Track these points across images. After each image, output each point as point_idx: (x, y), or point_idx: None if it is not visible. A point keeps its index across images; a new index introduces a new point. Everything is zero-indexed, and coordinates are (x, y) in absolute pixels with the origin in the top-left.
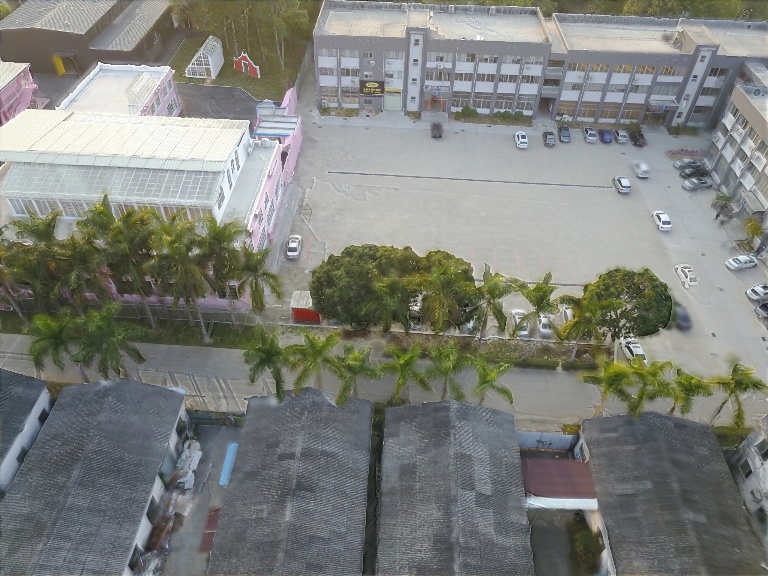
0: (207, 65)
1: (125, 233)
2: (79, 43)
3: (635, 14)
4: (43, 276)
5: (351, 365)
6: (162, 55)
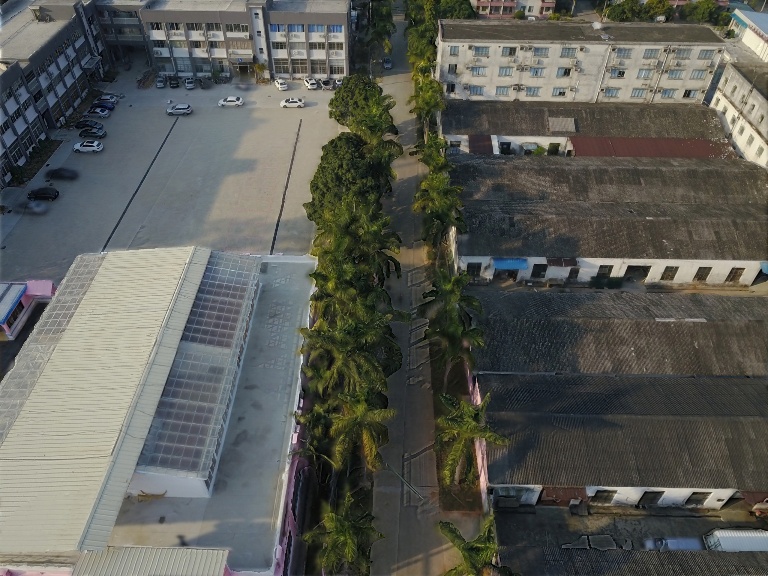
0: None
1: None
2: None
3: None
4: (384, 361)
5: None
6: None
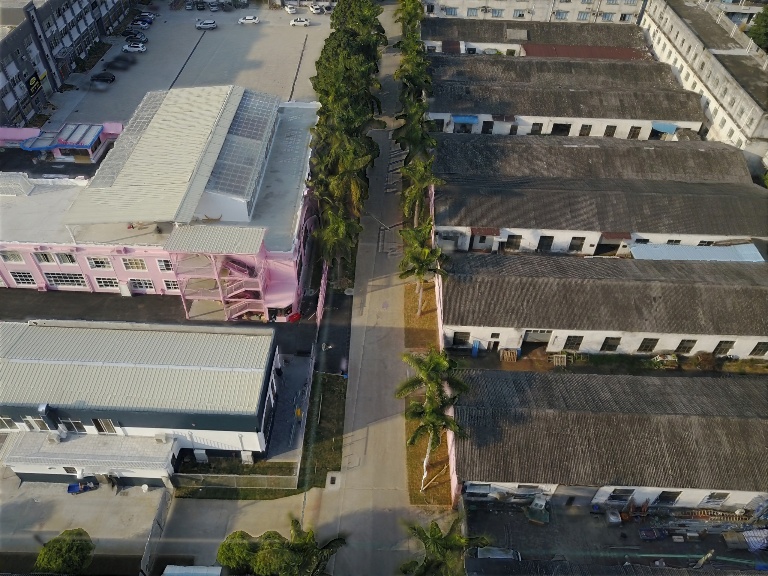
0: None
1: None
2: None
3: None
4: (367, 149)
5: None
6: None
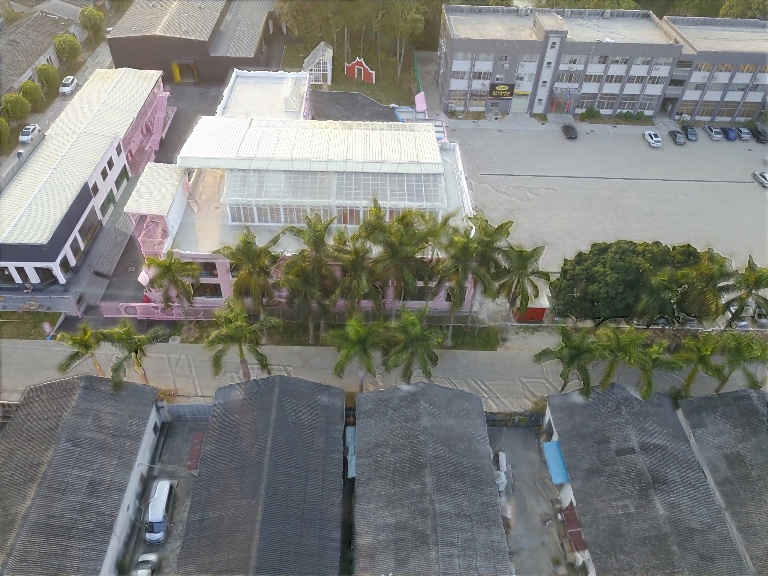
0: (325, 71)
1: (405, 236)
2: (200, 50)
3: (734, 17)
4: (318, 282)
5: (661, 358)
6: (270, 62)
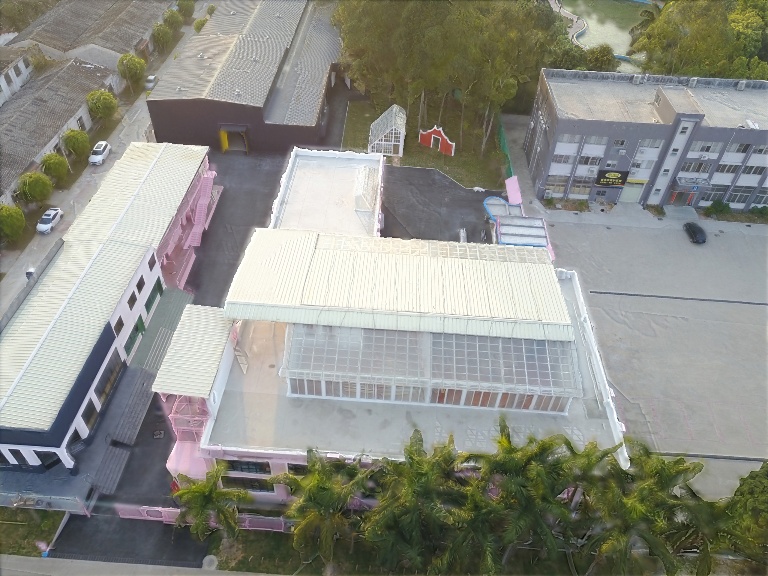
0: (397, 141)
1: (546, 482)
2: (254, 116)
3: None
4: (417, 539)
5: None
6: (331, 124)
